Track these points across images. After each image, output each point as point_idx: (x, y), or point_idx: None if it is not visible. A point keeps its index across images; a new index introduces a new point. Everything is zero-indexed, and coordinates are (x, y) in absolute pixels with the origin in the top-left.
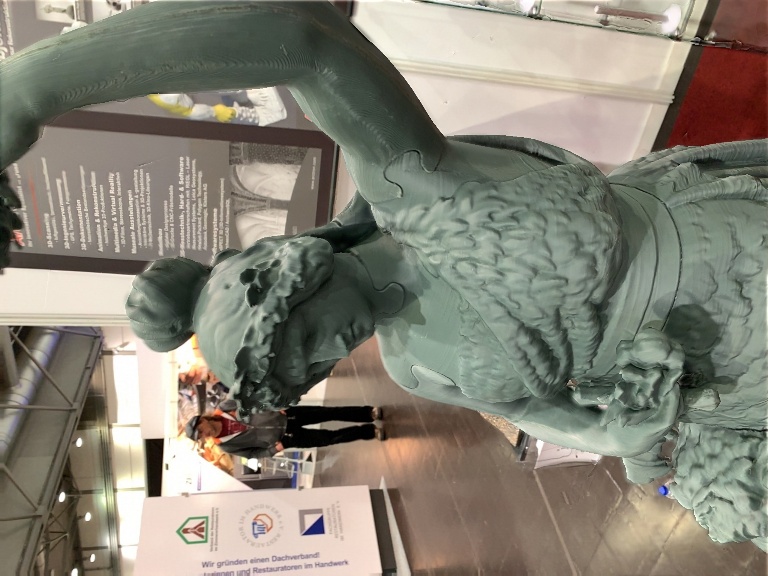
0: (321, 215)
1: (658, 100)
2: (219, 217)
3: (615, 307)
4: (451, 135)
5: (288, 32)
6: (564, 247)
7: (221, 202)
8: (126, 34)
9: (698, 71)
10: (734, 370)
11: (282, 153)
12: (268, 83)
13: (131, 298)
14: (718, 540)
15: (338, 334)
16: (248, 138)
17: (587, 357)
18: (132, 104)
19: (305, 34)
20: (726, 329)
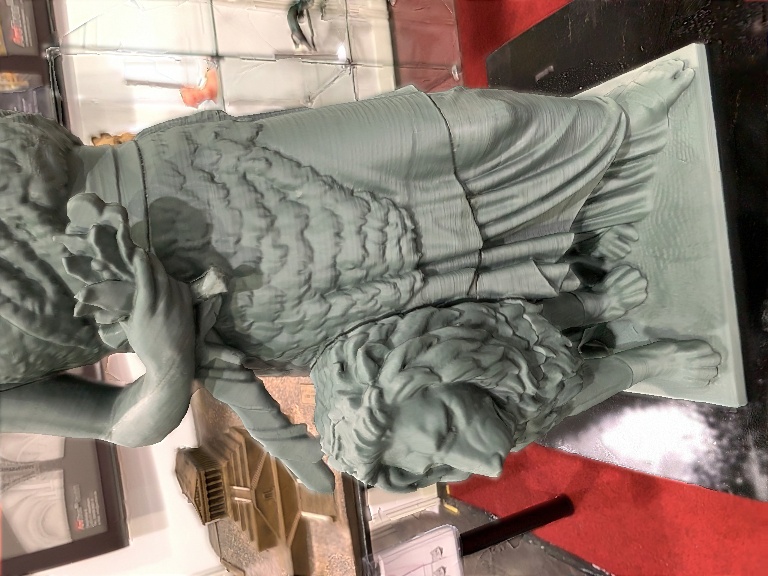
0: (105, 463)
1: None
2: None
3: None
4: None
5: None
6: None
7: None
8: None
9: None
10: (246, 256)
11: None
12: None
13: None
14: (360, 474)
15: None
16: None
17: None
18: None
19: None
20: (212, 214)
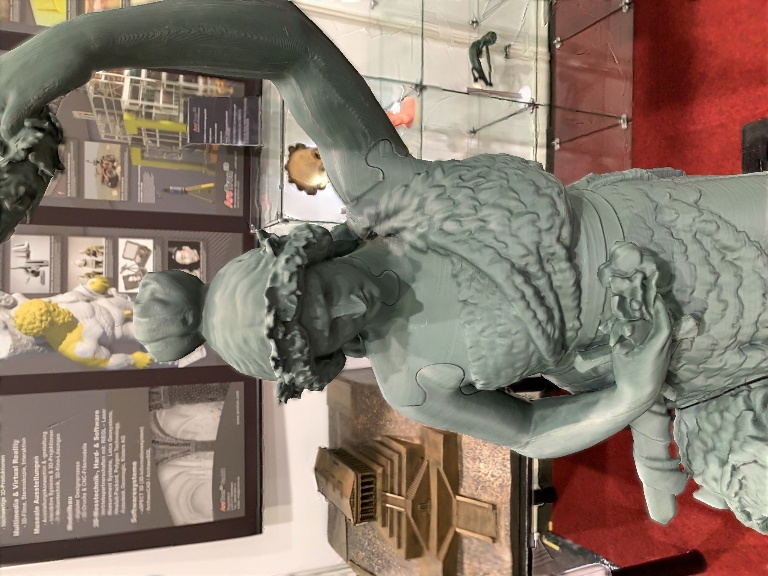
0: (250, 451)
1: None
2: (139, 471)
3: (582, 258)
4: None
5: (288, 20)
6: (527, 189)
7: (141, 453)
8: (169, 5)
9: None
10: (697, 306)
11: (204, 391)
12: (273, 64)
13: (139, 298)
14: (763, 514)
15: (352, 294)
16: (168, 381)
17: (574, 310)
18: (45, 363)
19: (300, 25)
20: (675, 266)
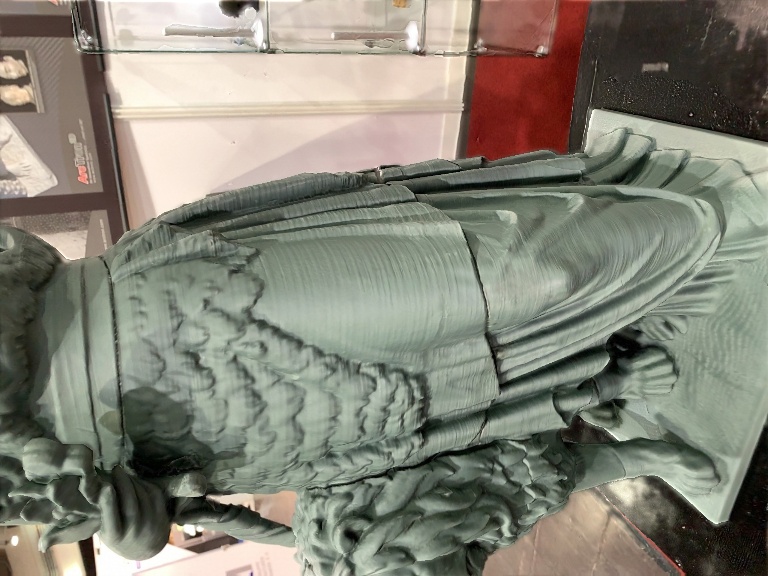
0: None
1: (450, 109)
2: None
3: (53, 407)
4: (249, 174)
5: None
6: None
7: None
8: None
9: (476, 78)
10: (229, 443)
11: (62, 221)
12: None
13: None
14: None
15: None
16: (19, 211)
17: None
18: None
19: None
20: (194, 405)
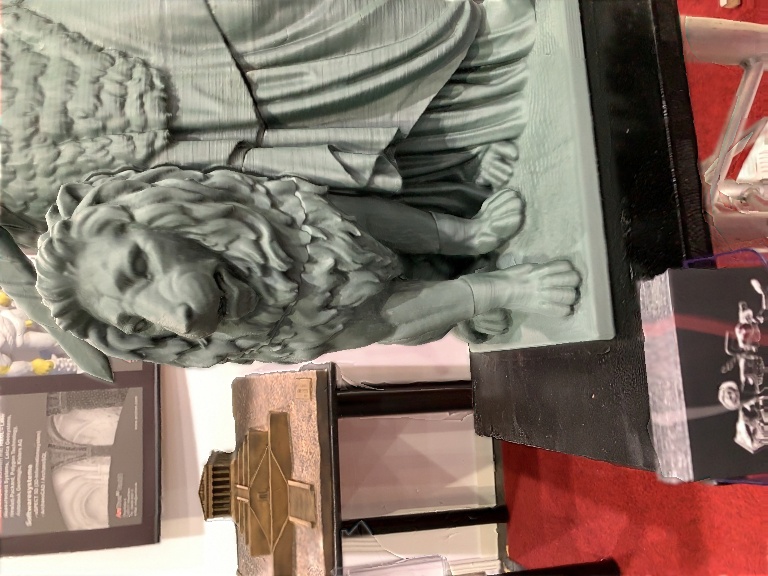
0: (149, 457)
1: None
2: (34, 474)
3: None
4: None
5: None
6: None
7: (36, 456)
8: None
9: None
10: None
11: (102, 397)
12: None
13: None
14: None
15: None
16: (67, 387)
17: None
18: None
19: None
20: None
